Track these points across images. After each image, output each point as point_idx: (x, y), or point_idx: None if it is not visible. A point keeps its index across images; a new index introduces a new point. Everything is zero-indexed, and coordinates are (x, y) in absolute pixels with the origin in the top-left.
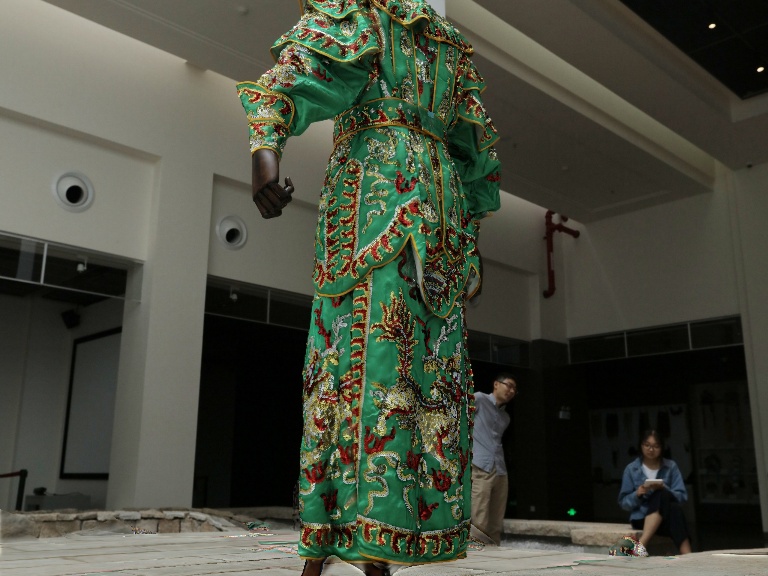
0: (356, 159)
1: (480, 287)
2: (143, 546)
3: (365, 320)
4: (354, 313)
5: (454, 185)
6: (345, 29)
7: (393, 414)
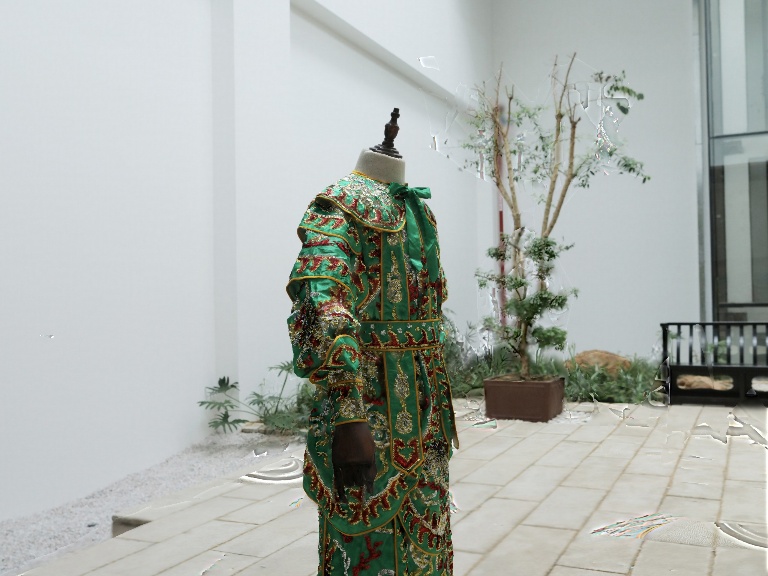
0: None
1: (339, 489)
2: None
3: None
4: None
5: None
6: None
7: None
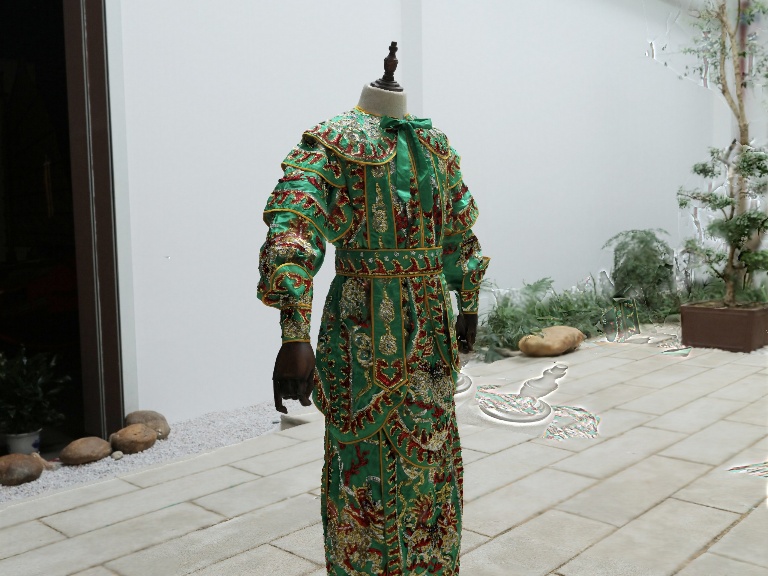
0: None
1: (277, 400)
2: None
3: None
4: None
5: None
6: None
7: None
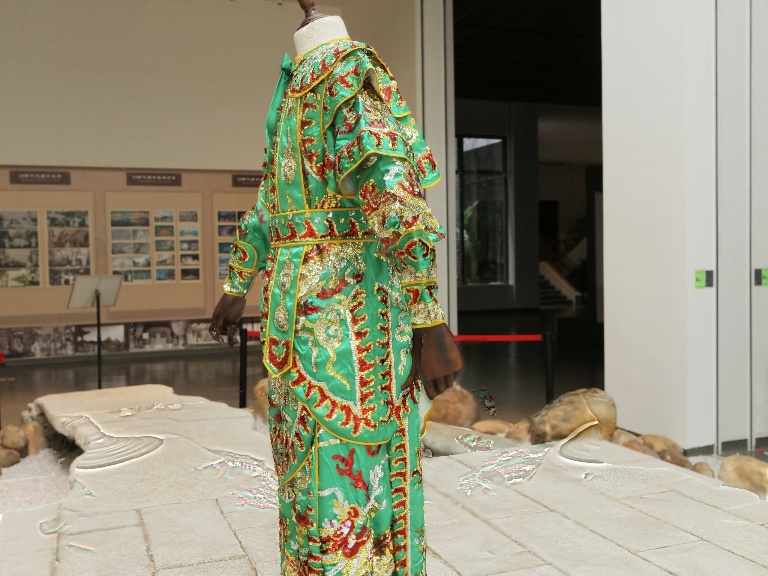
0: (385, 285)
1: None
2: None
3: (407, 468)
4: (396, 462)
5: None
6: None
7: None
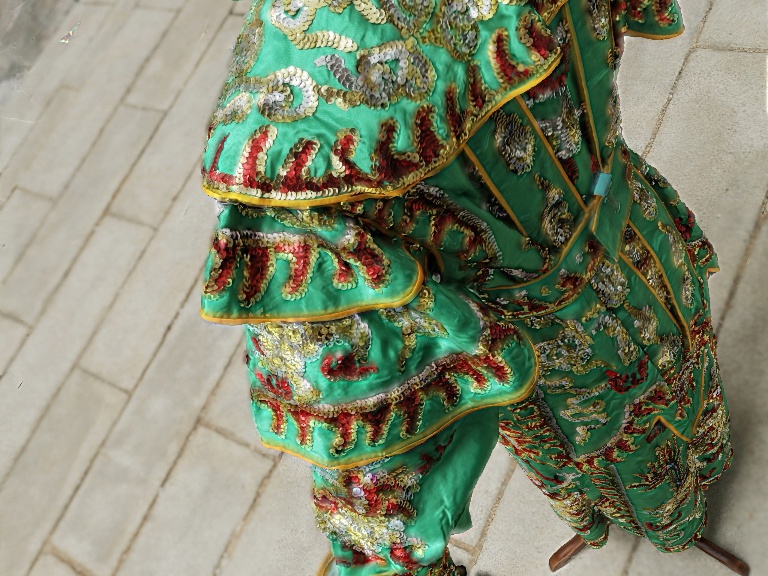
0: None
1: None
2: (128, 92)
3: None
4: None
5: (679, 248)
6: (398, 316)
7: (676, 509)
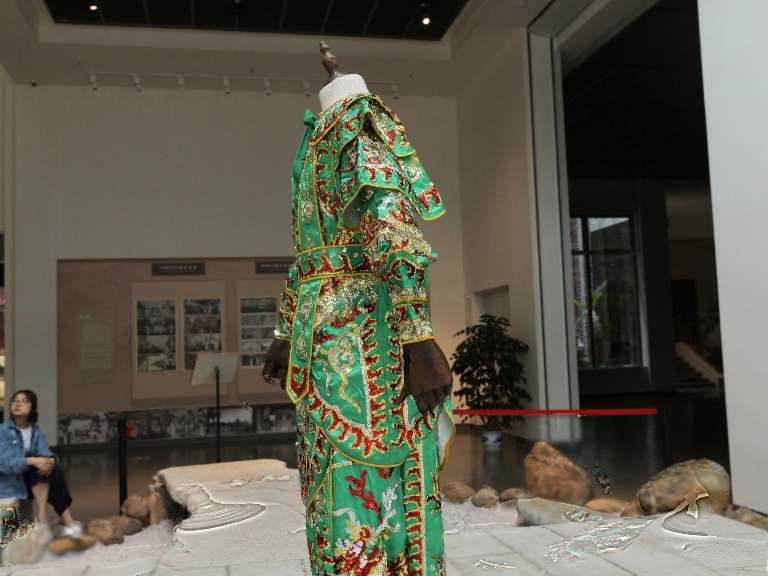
0: None
1: None
2: None
3: (421, 493)
4: (409, 486)
5: None
6: None
7: None
